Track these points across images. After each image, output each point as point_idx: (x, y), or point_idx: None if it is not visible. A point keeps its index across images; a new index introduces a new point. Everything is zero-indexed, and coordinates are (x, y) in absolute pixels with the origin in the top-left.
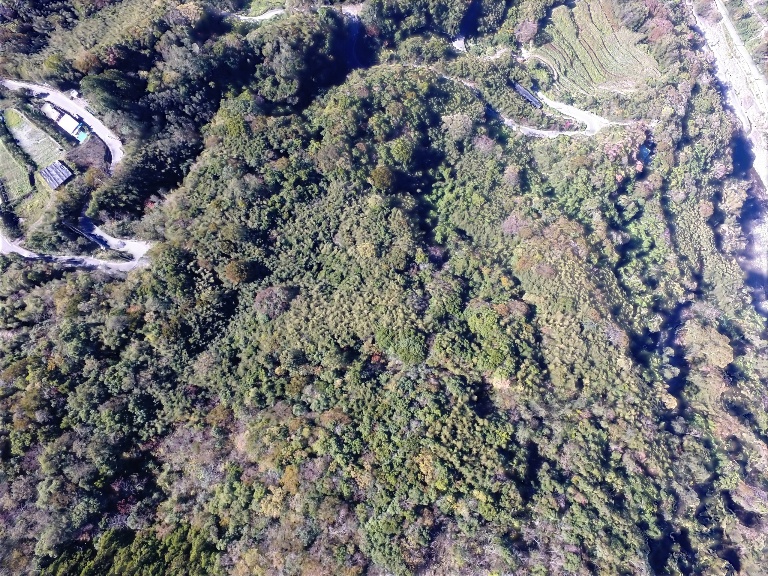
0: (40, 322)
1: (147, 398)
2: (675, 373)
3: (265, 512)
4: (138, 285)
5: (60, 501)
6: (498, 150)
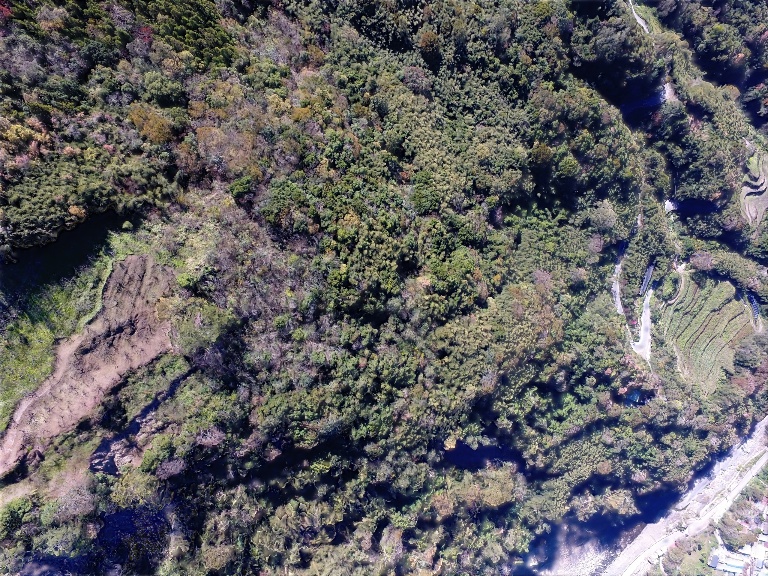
0: None
1: None
2: (473, 445)
3: (269, 99)
4: None
5: None
6: (595, 258)
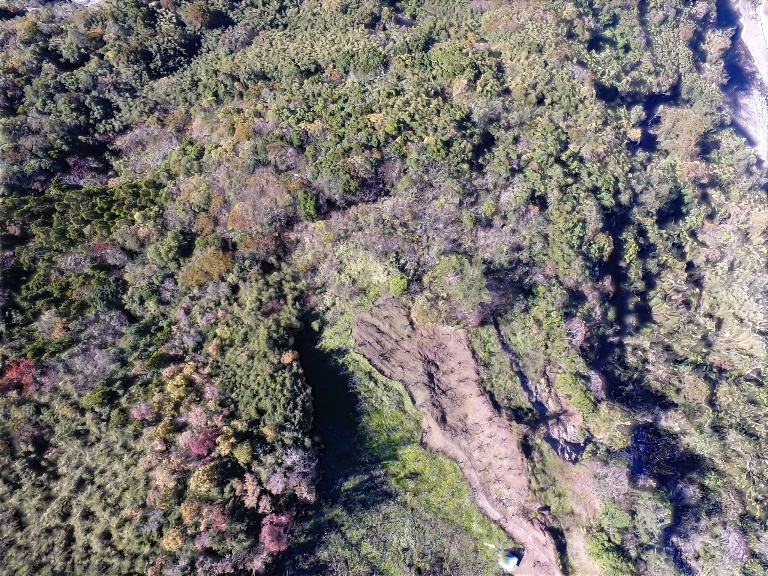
0: (1, 47)
1: (105, 101)
2: (641, 117)
3: (215, 158)
4: (98, 13)
5: (12, 157)
6: None
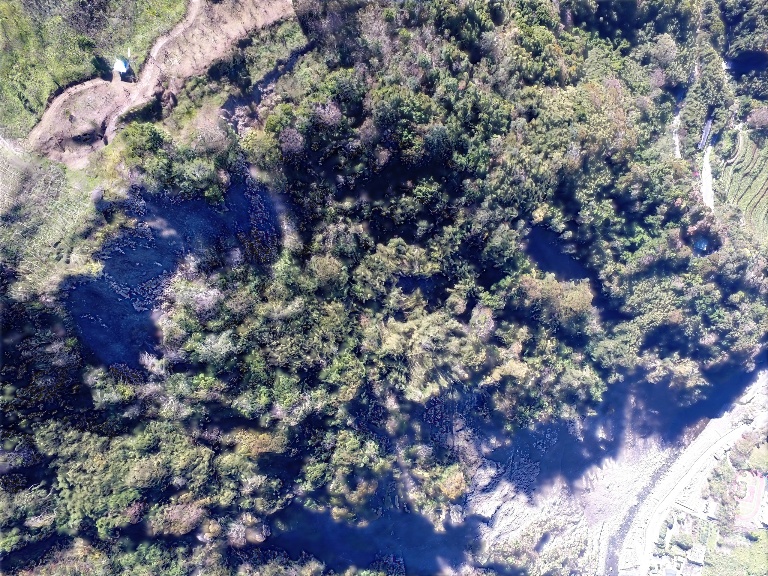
0: None
1: None
2: (559, 225)
3: None
4: None
5: None
6: (658, 91)
